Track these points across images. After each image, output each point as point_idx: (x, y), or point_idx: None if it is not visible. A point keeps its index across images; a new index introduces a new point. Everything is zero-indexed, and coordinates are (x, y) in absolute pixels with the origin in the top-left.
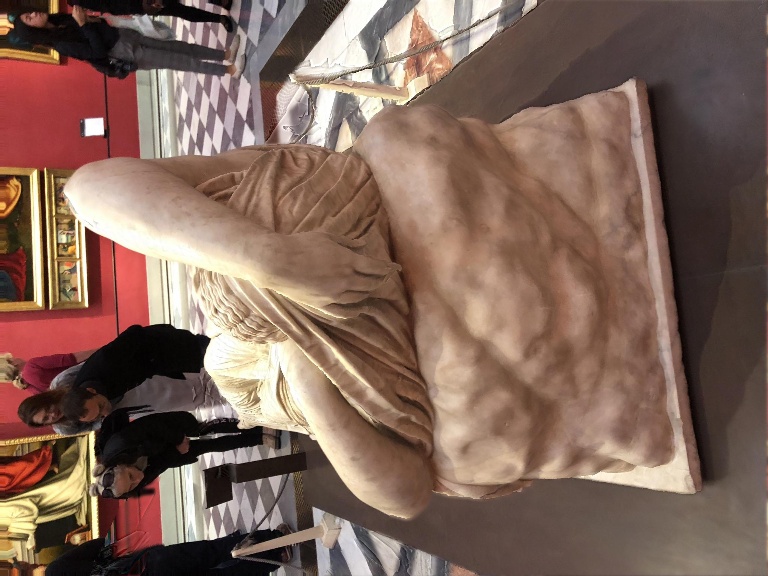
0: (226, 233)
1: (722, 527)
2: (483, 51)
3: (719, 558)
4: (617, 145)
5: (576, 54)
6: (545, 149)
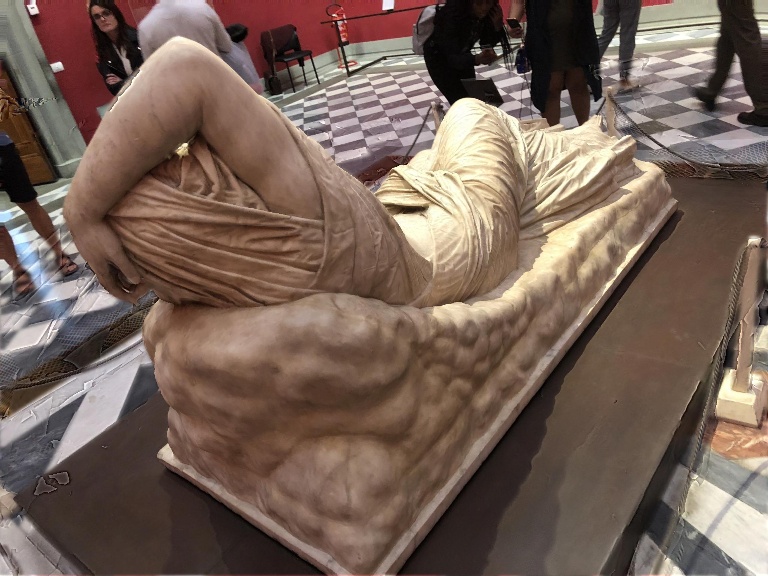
0: (80, 183)
1: (147, 463)
2: (638, 494)
3: (141, 453)
4: (320, 539)
5: (489, 574)
6: (312, 472)
